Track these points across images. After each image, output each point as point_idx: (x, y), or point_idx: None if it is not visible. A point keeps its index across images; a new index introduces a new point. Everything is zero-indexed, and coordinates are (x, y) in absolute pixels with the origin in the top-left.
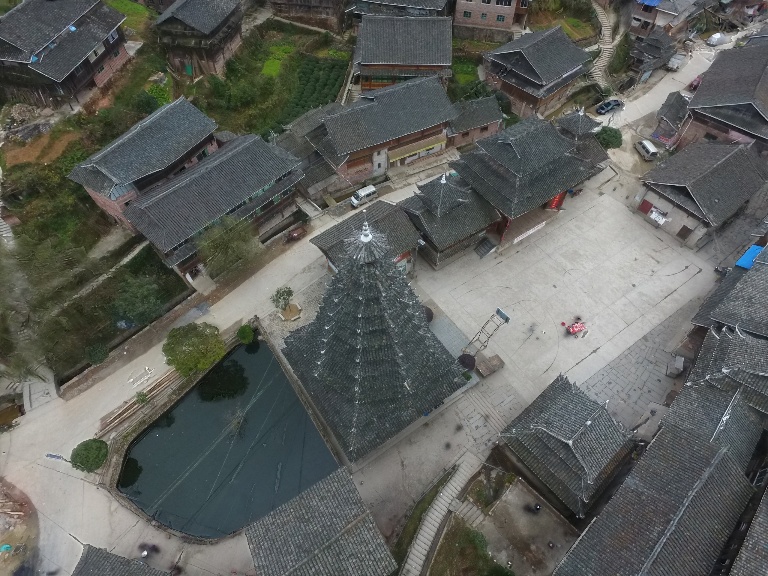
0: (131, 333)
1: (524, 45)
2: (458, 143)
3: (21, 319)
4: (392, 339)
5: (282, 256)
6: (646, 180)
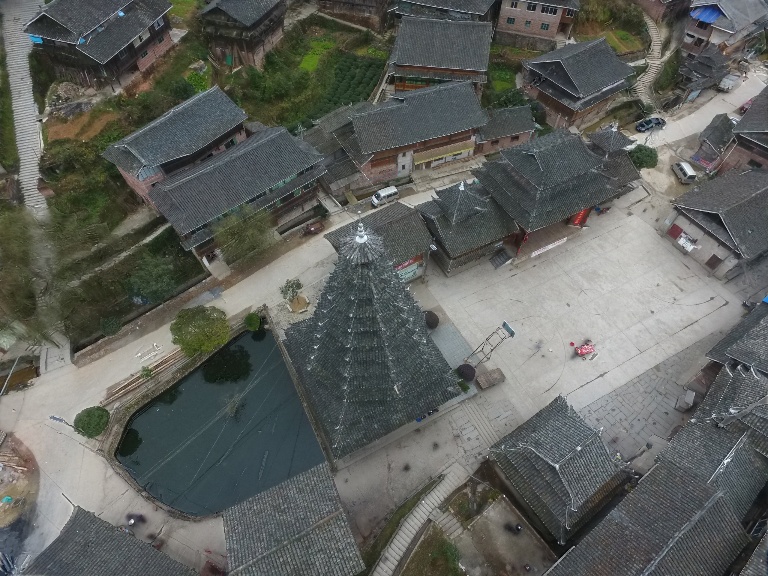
0: (146, 309)
1: (564, 55)
2: (487, 150)
3: (40, 286)
4: (383, 342)
5: (298, 249)
6: (677, 204)
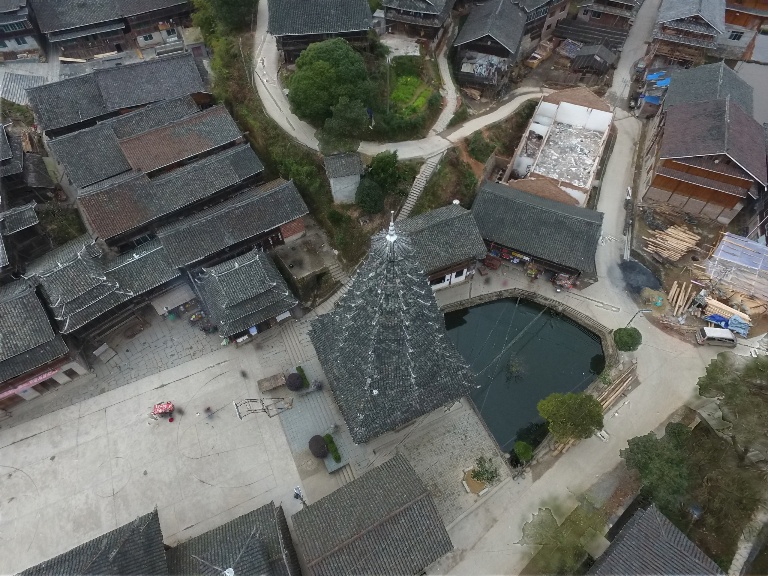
0: None
1: None
2: None
3: None
4: None
5: None
6: None
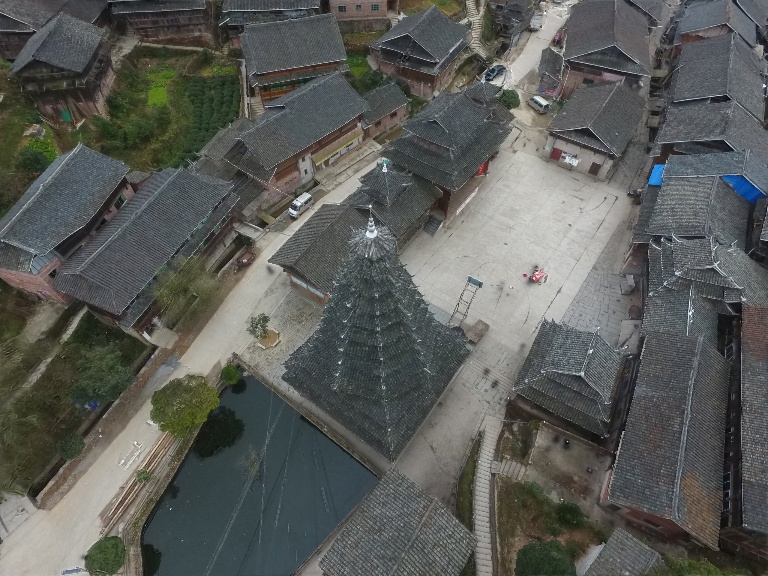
0: (97, 414)
1: (409, 28)
2: (373, 134)
3: None
4: (409, 328)
5: (238, 286)
6: (552, 130)
